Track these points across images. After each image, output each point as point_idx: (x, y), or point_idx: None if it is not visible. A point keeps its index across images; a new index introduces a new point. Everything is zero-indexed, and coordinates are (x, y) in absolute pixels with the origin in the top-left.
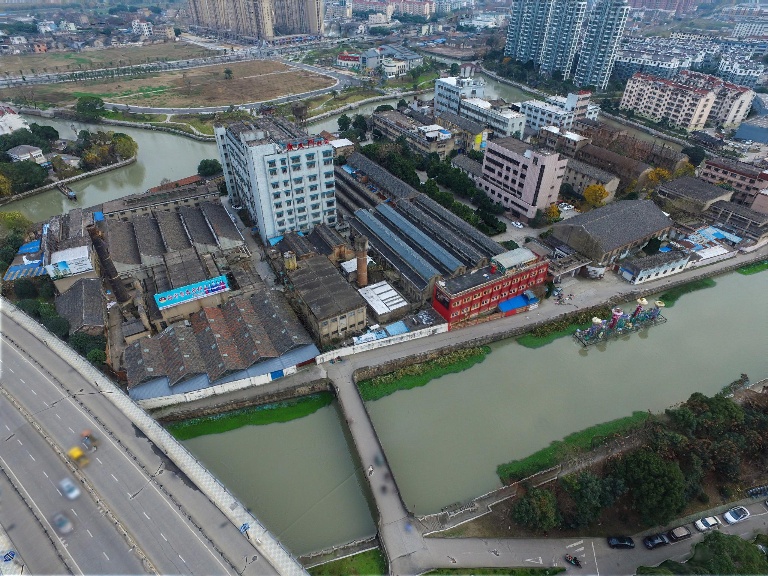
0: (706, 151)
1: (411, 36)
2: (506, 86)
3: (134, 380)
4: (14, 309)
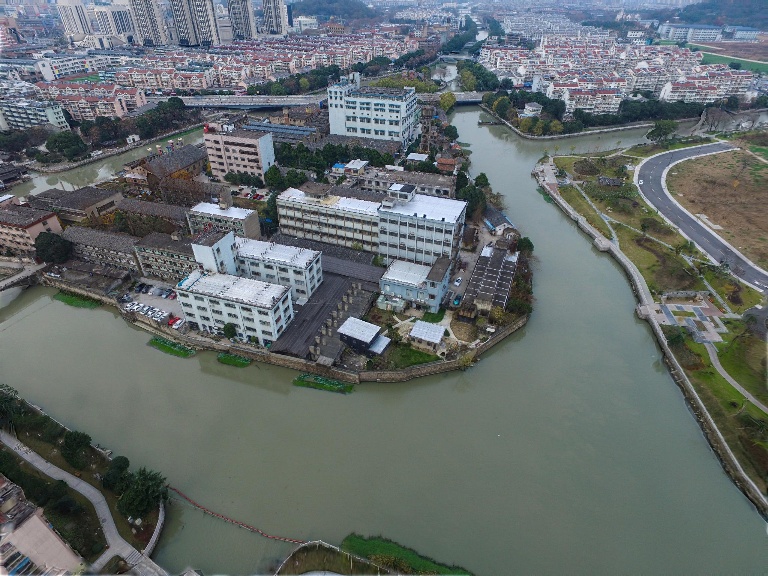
0: None
1: None
2: None
3: None
4: None
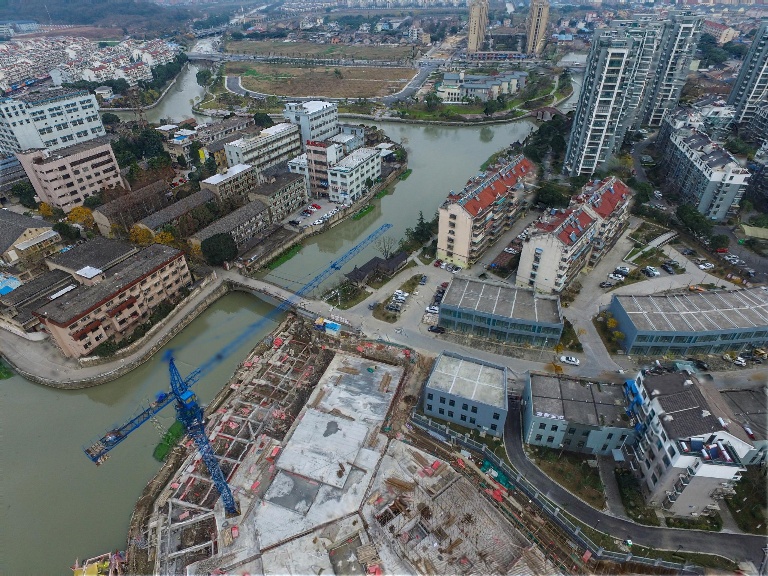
0: None
1: None
2: None
3: None
4: None
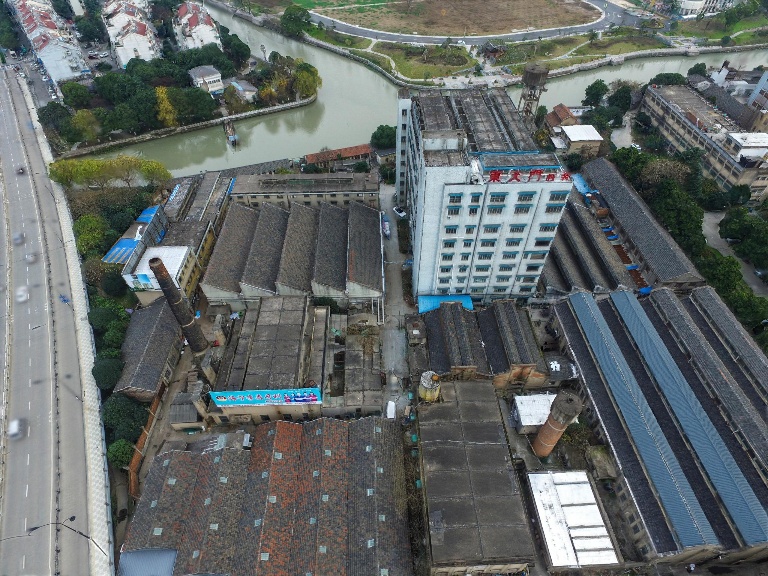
0: None
1: None
2: None
3: (133, 539)
4: (86, 316)
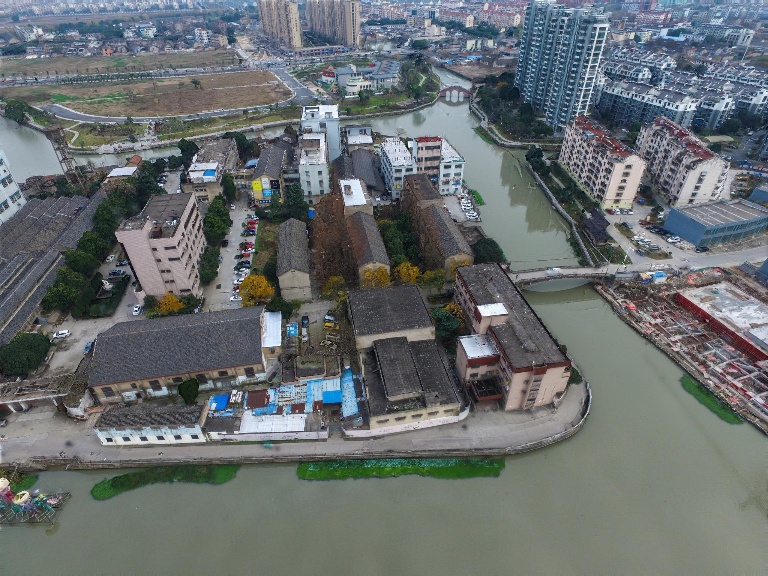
0: (582, 243)
1: (452, 51)
2: (475, 117)
3: None
4: None
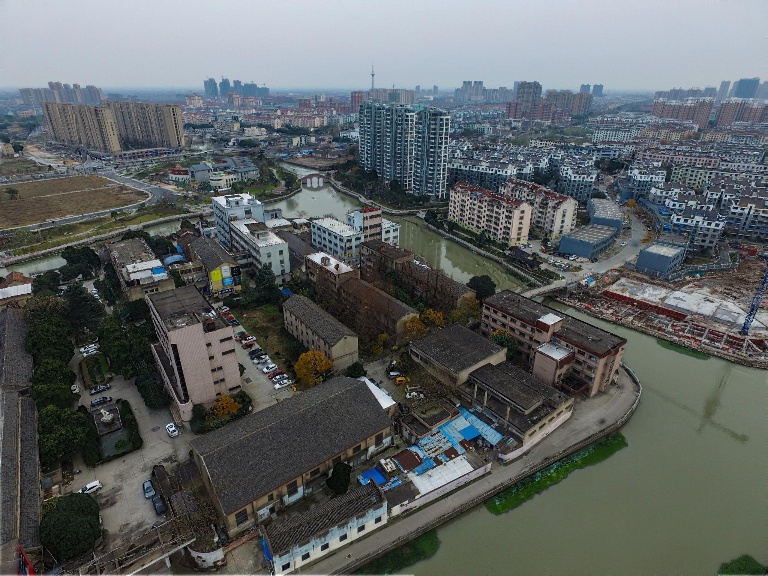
0: (521, 272)
1: (281, 147)
2: (347, 197)
3: None
4: None
